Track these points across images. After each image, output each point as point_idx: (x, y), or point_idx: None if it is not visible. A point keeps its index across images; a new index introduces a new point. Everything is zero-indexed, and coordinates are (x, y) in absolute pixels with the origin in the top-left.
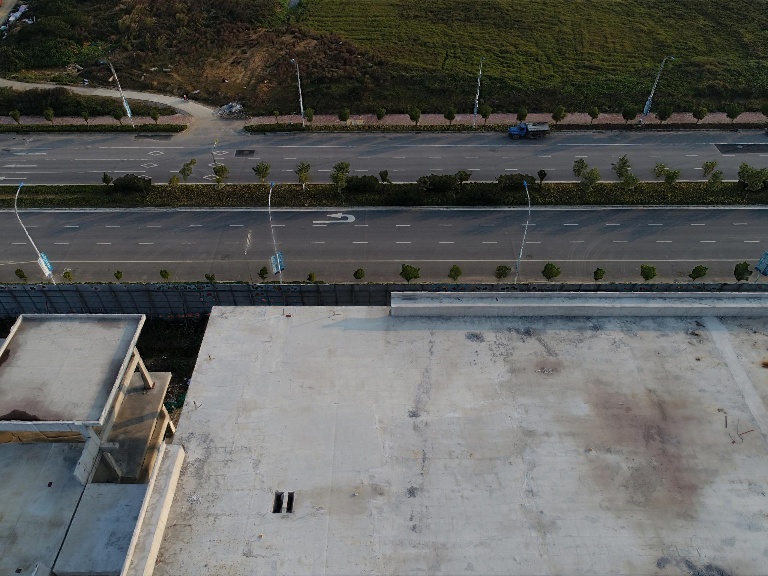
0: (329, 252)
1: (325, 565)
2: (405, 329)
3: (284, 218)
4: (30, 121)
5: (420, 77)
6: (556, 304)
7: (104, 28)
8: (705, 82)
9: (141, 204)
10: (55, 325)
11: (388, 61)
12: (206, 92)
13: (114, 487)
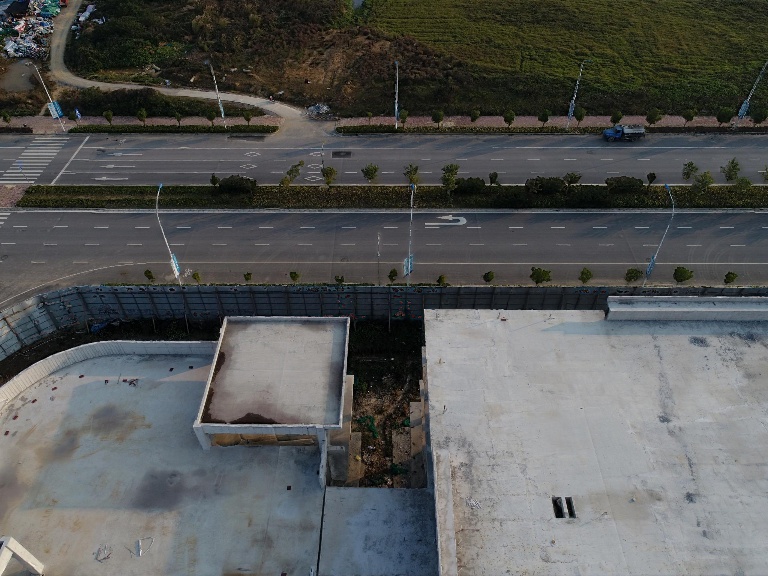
0: (448, 254)
1: (628, 571)
2: (626, 333)
3: (395, 220)
4: (120, 121)
5: (503, 79)
6: None
7: (177, 28)
8: None
9: (249, 205)
10: (262, 327)
11: (467, 63)
12: (291, 93)
13: (354, 490)
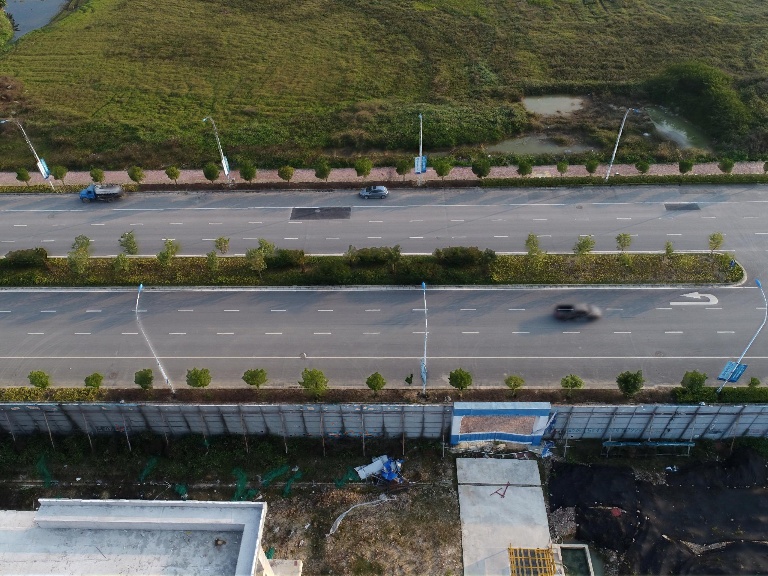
0: None
1: None
2: None
3: None
4: None
5: (51, 127)
6: None
7: None
8: (346, 131)
9: None
10: None
11: (37, 108)
12: None
13: None
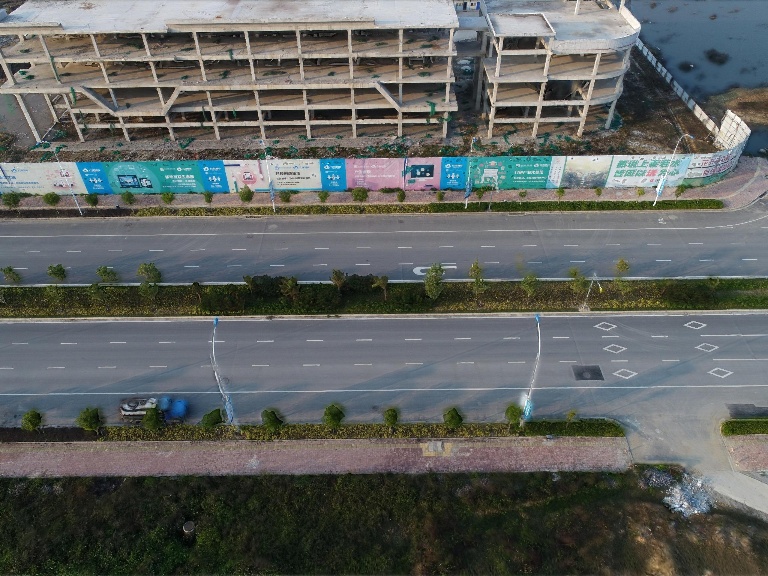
0: (433, 239)
1: None
2: None
3: (488, 270)
4: None
5: None
6: None
7: None
8: None
9: None
10: None
11: None
12: None
13: None
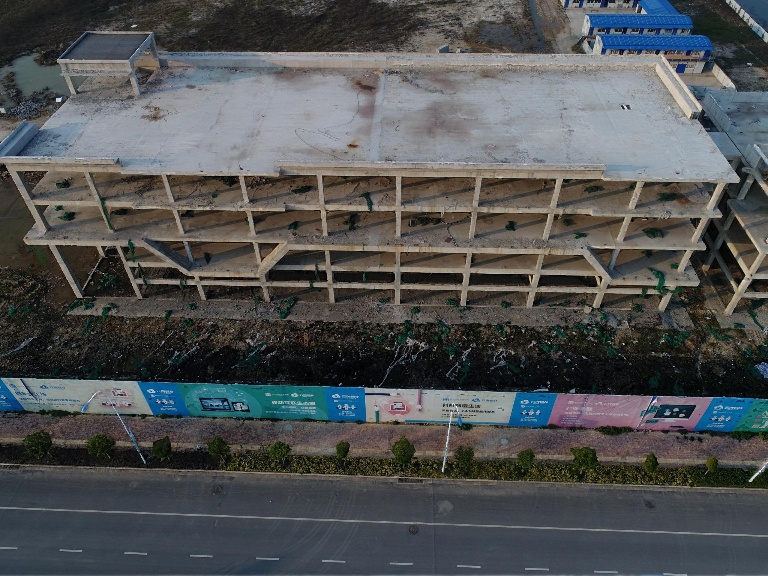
0: (716, 553)
1: None
2: None
3: None
4: None
5: None
6: (484, 163)
7: None
8: None
9: None
10: None
11: None
12: None
13: (726, 154)
